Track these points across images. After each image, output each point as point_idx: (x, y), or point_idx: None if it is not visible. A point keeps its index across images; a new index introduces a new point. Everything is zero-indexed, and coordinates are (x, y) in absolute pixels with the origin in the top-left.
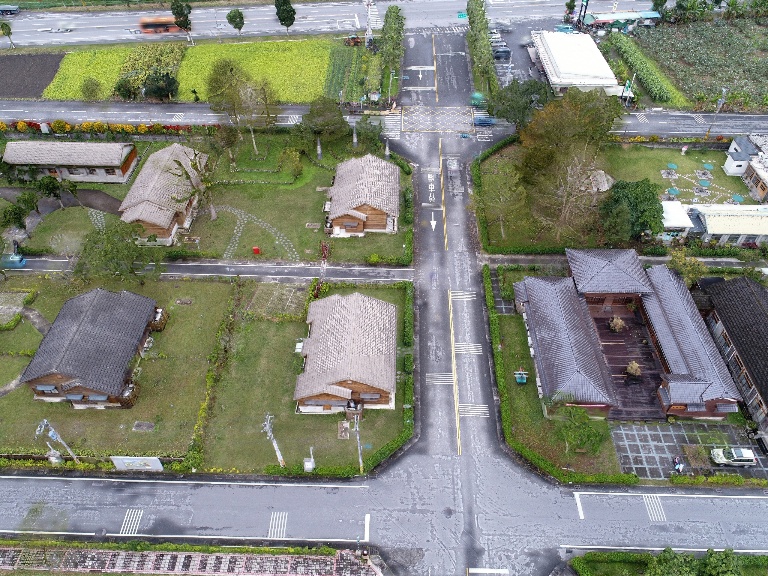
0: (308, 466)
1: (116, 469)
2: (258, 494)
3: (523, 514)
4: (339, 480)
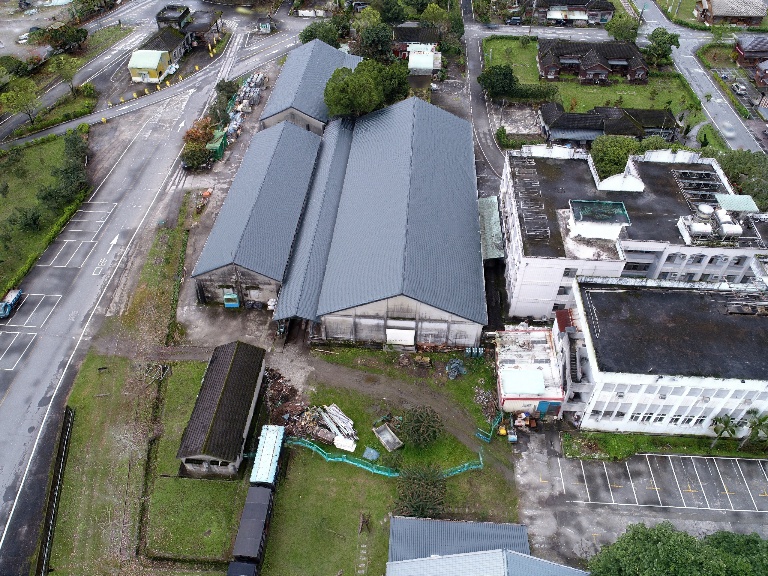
0: None
1: None
2: (653, 6)
3: None
4: (667, 18)
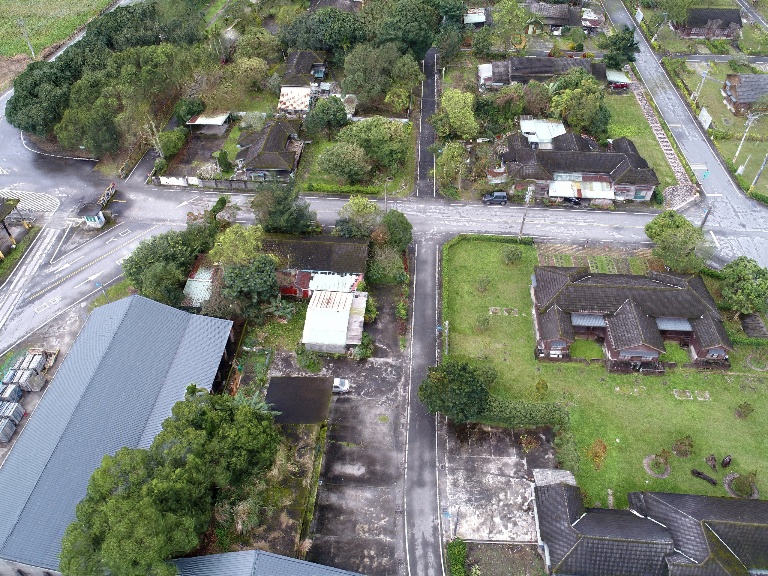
0: (739, 171)
1: (698, 117)
2: (711, 159)
3: (761, 257)
4: (738, 186)
